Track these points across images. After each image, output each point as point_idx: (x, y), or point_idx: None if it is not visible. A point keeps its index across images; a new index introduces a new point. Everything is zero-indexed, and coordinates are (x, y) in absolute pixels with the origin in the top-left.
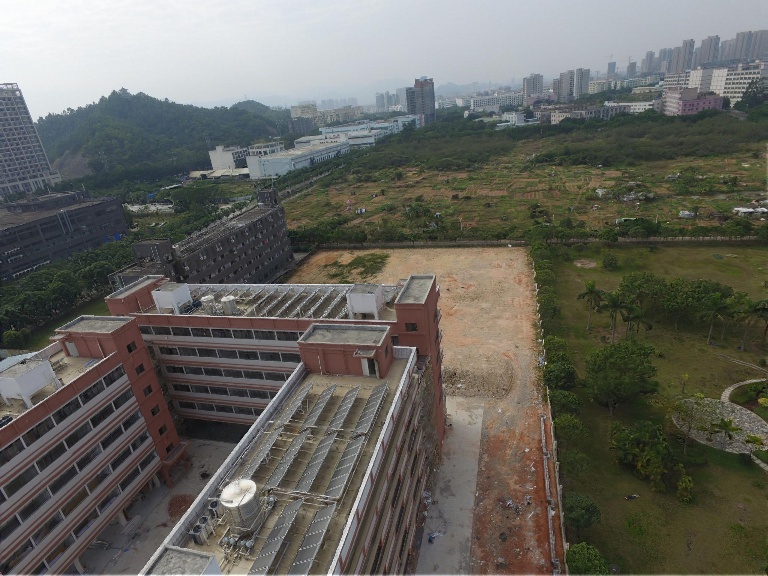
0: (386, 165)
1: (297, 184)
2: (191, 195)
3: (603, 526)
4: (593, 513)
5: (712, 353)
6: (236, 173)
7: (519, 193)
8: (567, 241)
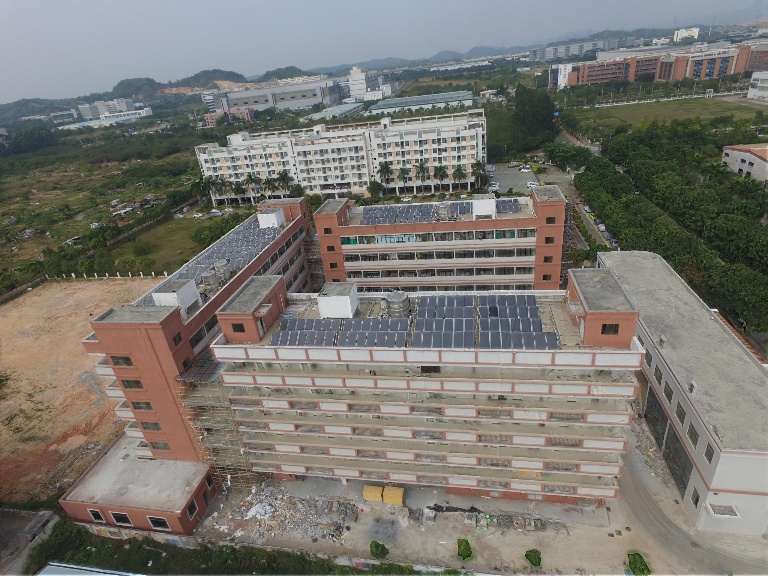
0: None
1: None
2: None
3: None
4: None
5: None
6: None
7: None
8: None
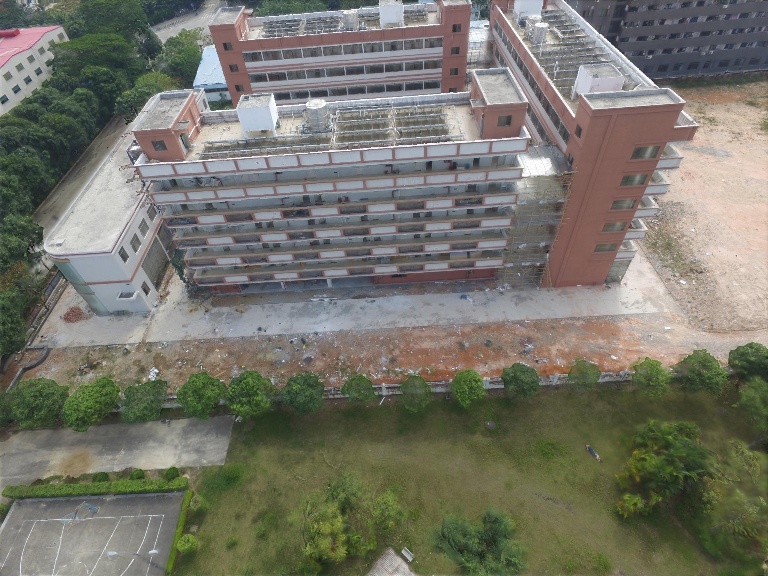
0: None
1: None
2: None
3: (537, 420)
4: (518, 386)
5: None
6: None
7: None
8: None
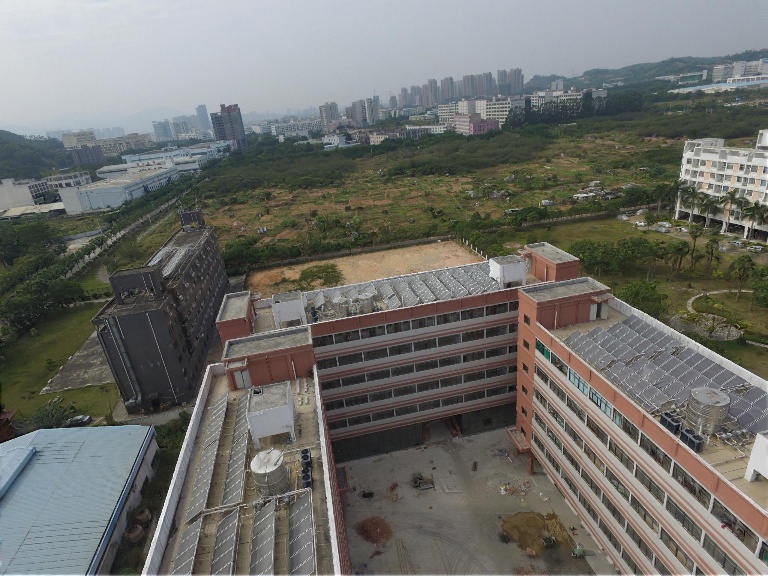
0: (240, 188)
1: (146, 214)
2: (25, 235)
3: None
4: None
5: (656, 287)
6: (44, 209)
7: (402, 200)
8: (484, 231)
